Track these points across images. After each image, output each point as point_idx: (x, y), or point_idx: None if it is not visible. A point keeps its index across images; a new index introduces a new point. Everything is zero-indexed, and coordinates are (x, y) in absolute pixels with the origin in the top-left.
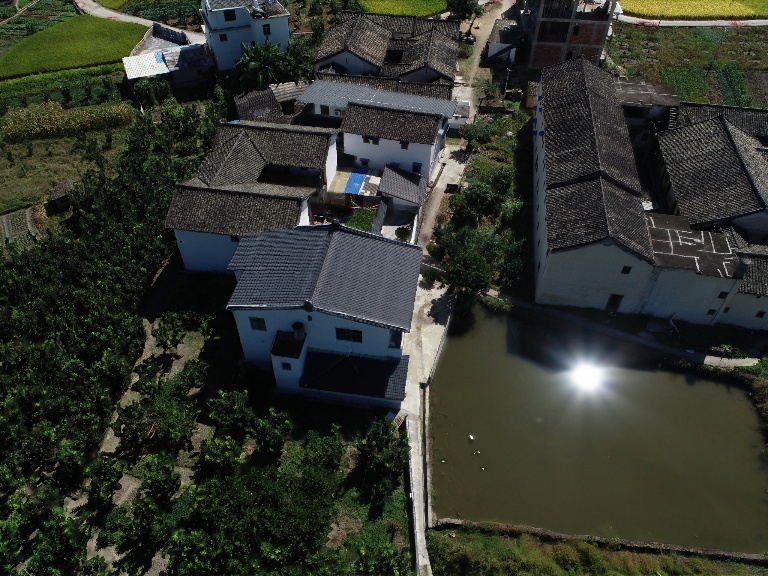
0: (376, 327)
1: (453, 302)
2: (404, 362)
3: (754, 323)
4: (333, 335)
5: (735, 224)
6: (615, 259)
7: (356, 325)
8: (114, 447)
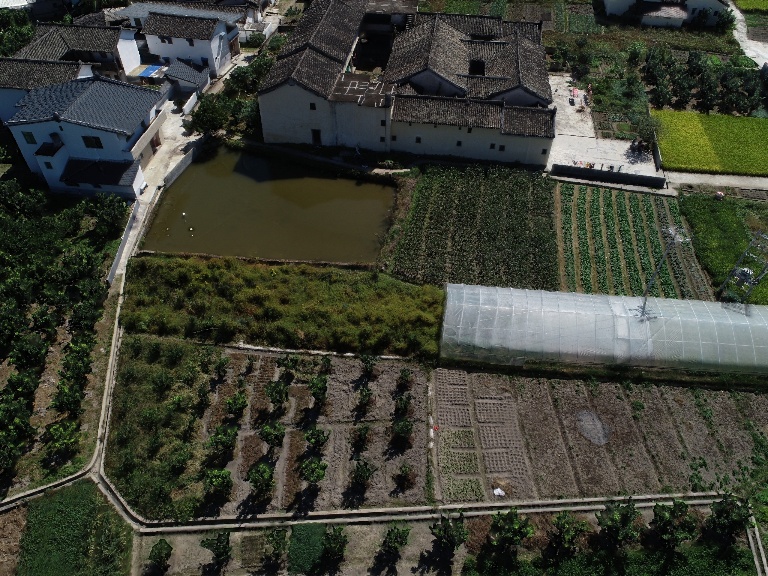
0: (107, 132)
1: (200, 141)
2: (136, 163)
3: (418, 149)
4: (82, 143)
5: (413, 82)
6: (302, 97)
7: (93, 132)
8: None
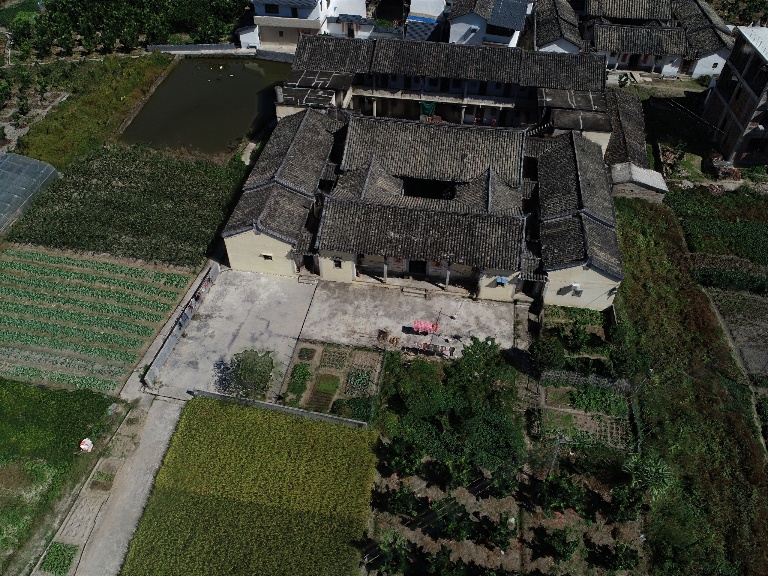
0: None
1: None
2: None
3: None
4: None
5: None
6: None
7: None
8: None
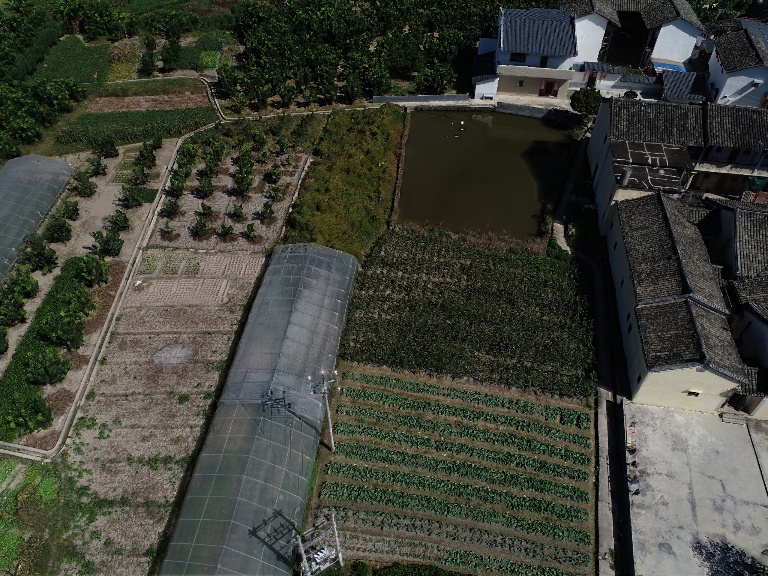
0: None
1: (567, 113)
2: None
3: None
4: None
5: None
6: None
7: None
8: (437, 36)
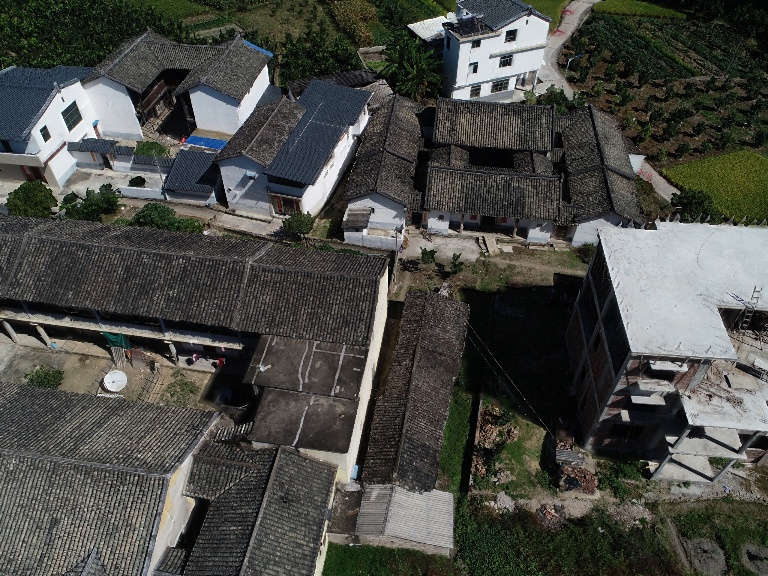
0: None
1: None
2: None
3: None
4: None
5: None
6: None
7: None
8: None
